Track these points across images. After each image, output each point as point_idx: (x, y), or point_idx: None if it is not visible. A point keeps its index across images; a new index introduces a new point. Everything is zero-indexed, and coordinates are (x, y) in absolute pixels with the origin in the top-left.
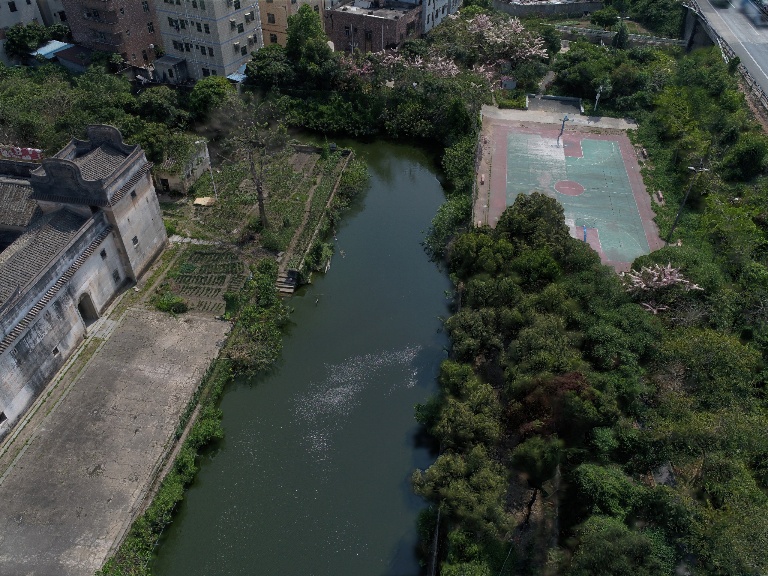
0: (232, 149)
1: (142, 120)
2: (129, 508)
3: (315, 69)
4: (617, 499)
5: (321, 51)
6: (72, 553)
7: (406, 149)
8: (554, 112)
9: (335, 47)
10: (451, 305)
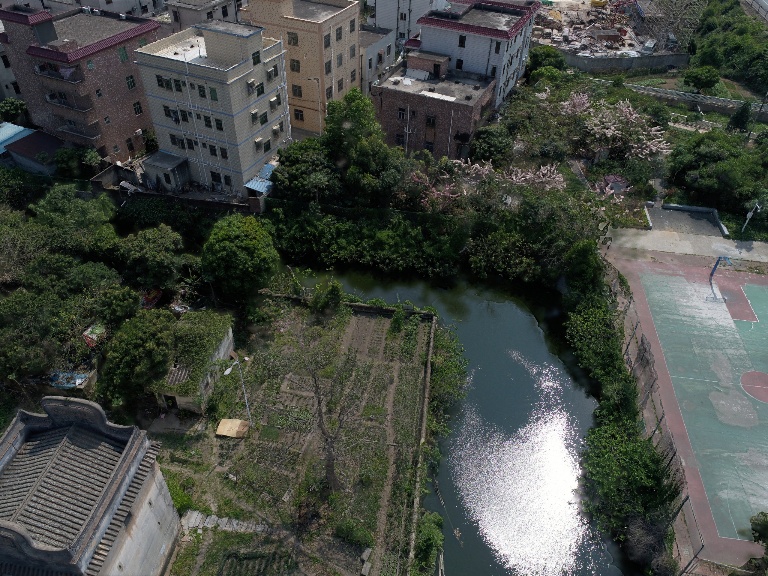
0: (266, 325)
1: (133, 293)
2: None
3: (372, 183)
4: None
5: (378, 156)
6: None
7: None
8: (687, 233)
9: (383, 132)
10: None
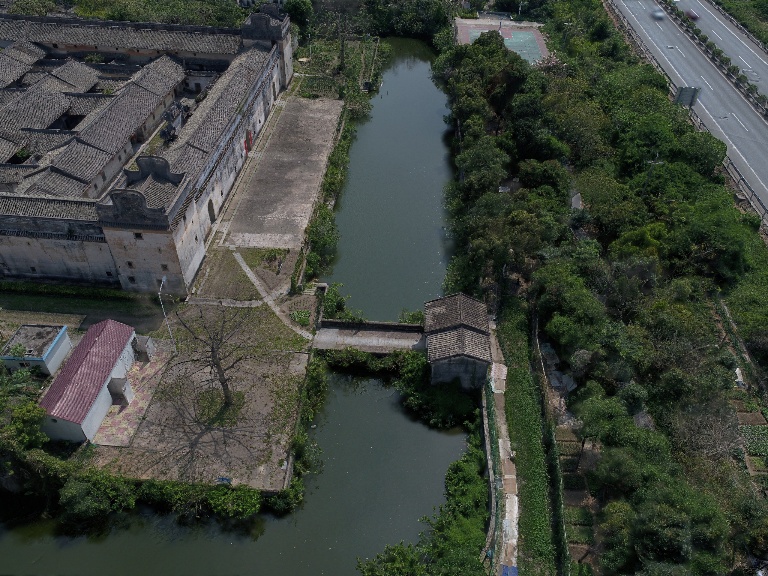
0: (311, 35)
1: None
2: (328, 147)
3: None
4: None
5: None
6: (312, 157)
7: (408, 42)
8: (495, 20)
9: None
10: (450, 95)
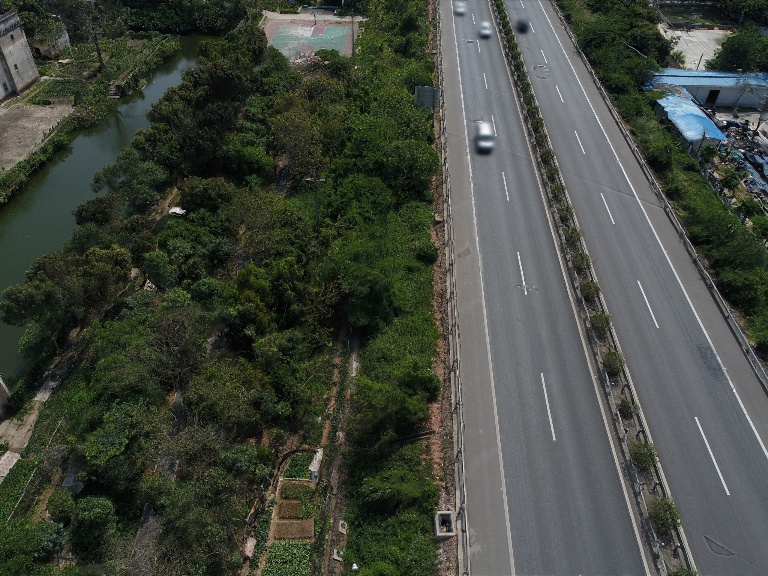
0: (85, 34)
1: (19, 13)
2: None
3: None
4: (254, 132)
5: None
6: None
7: None
8: (316, 14)
9: None
10: None
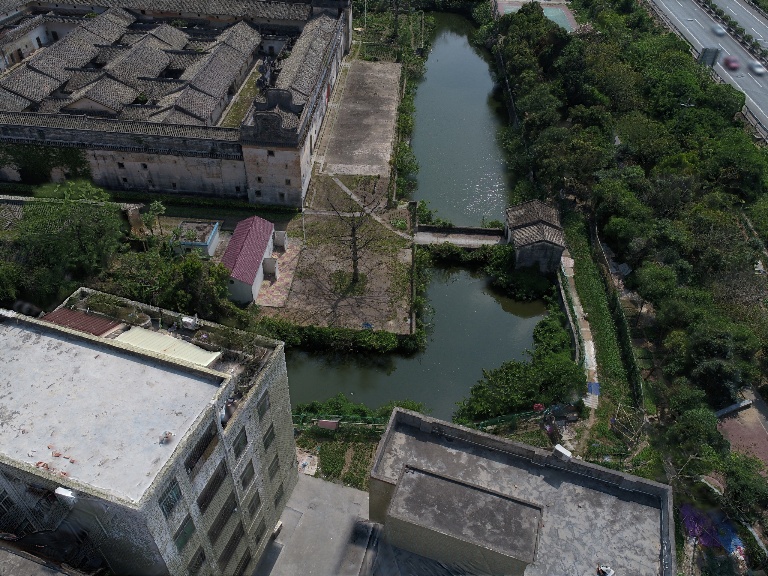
0: (363, 8)
1: None
2: (395, 100)
3: None
4: None
5: None
6: None
7: (447, 17)
8: None
9: None
10: (494, 60)
